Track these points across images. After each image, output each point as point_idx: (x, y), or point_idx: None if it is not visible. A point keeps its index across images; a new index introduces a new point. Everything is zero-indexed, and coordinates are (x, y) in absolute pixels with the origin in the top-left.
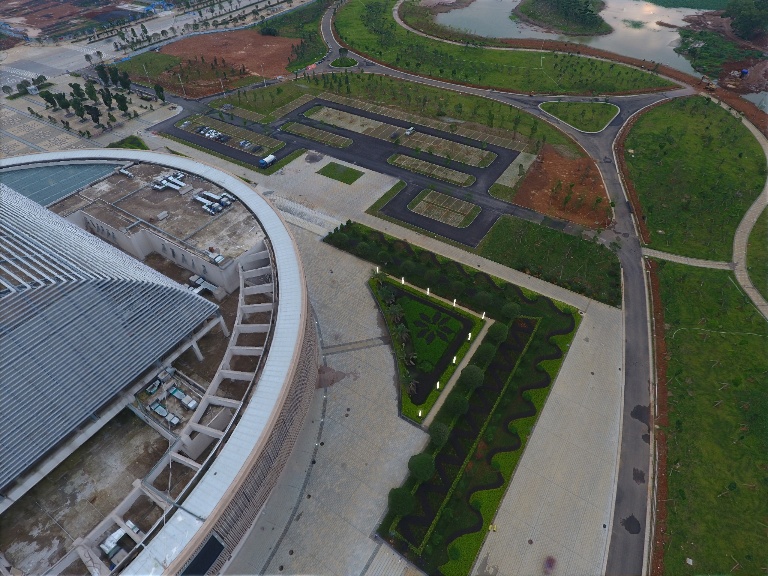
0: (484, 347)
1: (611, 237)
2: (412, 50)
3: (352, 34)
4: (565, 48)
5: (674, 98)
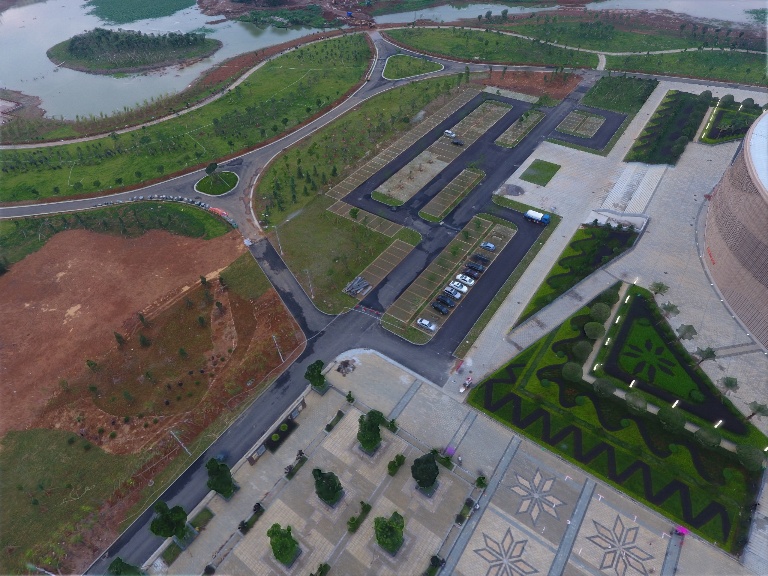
0: (752, 100)
1: (589, 76)
2: (218, 128)
3: (88, 180)
4: (256, 58)
5: (403, 32)
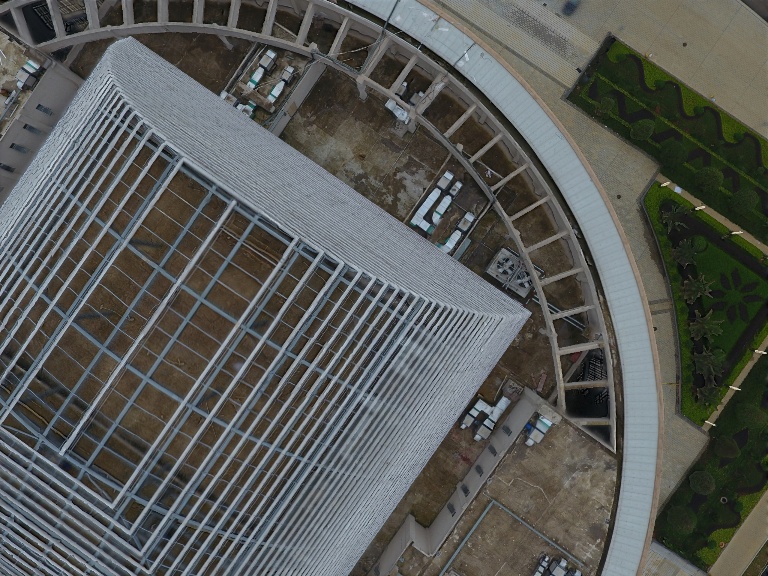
0: None
1: None
2: None
3: None
4: None
5: None
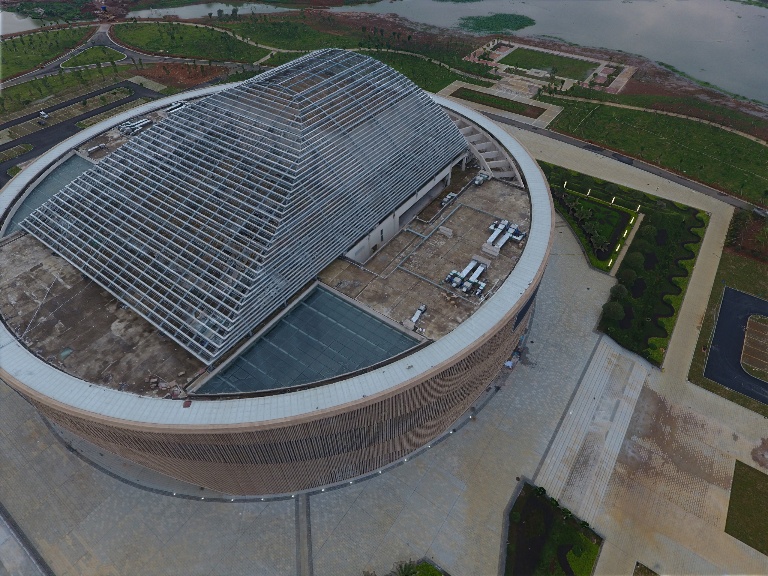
0: None
1: (238, 69)
2: None
3: None
4: None
5: (118, 26)
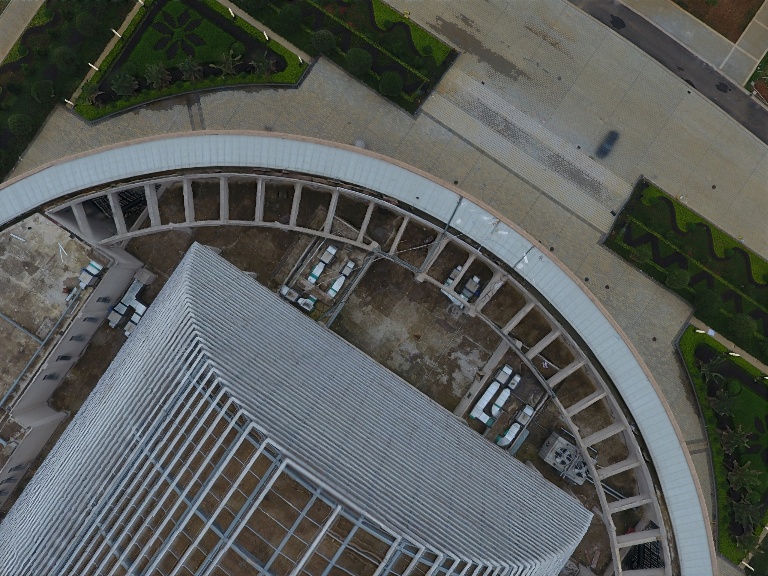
0: None
1: None
2: None
3: None
4: None
5: None
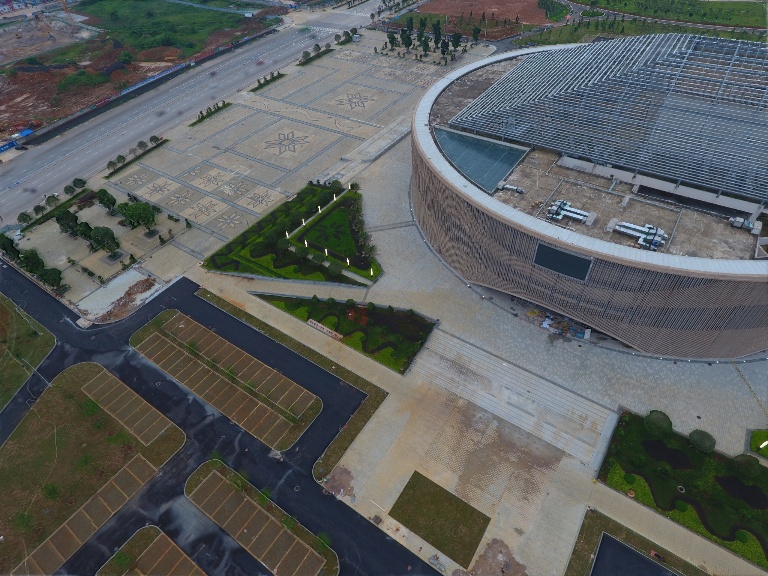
0: None
1: None
2: (645, 3)
3: None
4: None
5: None
